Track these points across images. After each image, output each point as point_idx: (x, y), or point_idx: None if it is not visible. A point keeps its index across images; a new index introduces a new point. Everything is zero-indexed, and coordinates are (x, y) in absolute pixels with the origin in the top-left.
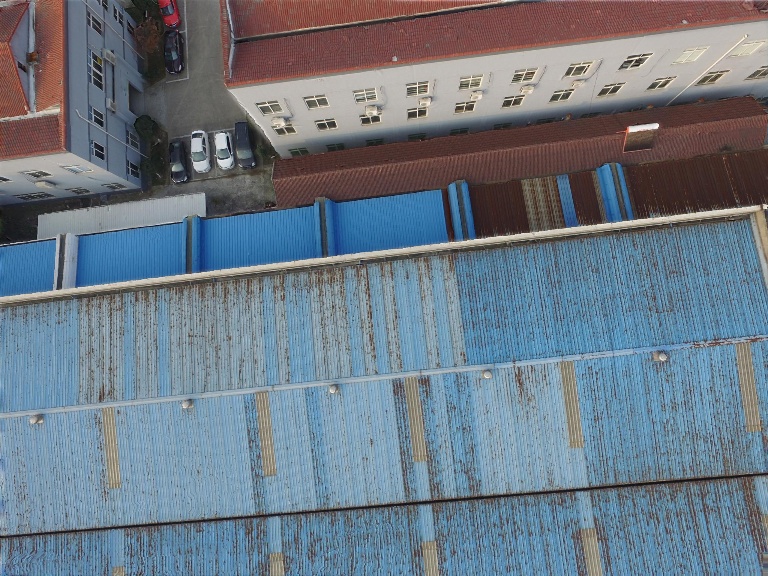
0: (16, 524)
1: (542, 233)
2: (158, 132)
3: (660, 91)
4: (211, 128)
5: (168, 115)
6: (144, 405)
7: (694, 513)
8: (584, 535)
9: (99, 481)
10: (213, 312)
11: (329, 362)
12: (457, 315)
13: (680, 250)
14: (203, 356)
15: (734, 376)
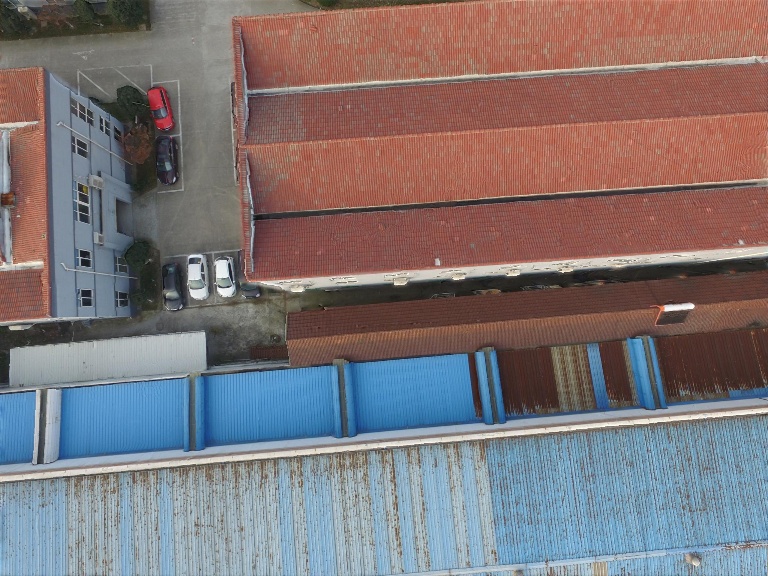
0: None
1: (579, 428)
2: (149, 251)
3: (692, 259)
4: (209, 248)
5: (160, 231)
6: None
7: None
8: None
9: None
10: (222, 498)
11: (352, 558)
12: (488, 509)
13: (714, 445)
14: (212, 549)
15: None
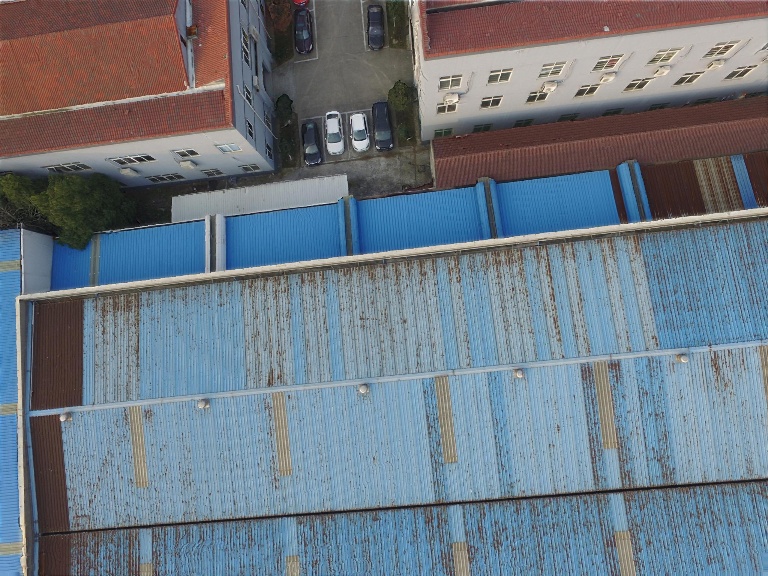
0: (181, 512)
1: (738, 213)
2: None
3: None
4: (343, 109)
5: (297, 96)
6: (316, 390)
7: None
8: None
9: (269, 468)
10: (385, 294)
11: (512, 346)
12: (646, 298)
13: None
14: (377, 339)
15: None
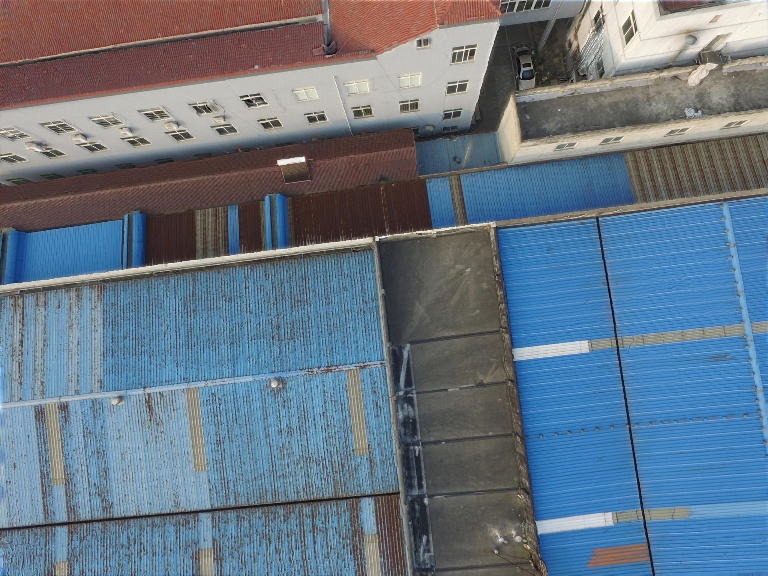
0: None
1: (174, 265)
2: None
3: (327, 124)
4: None
5: None
6: None
7: (303, 534)
8: (202, 555)
9: None
10: None
11: None
12: (99, 343)
13: (306, 280)
14: None
15: (345, 402)
